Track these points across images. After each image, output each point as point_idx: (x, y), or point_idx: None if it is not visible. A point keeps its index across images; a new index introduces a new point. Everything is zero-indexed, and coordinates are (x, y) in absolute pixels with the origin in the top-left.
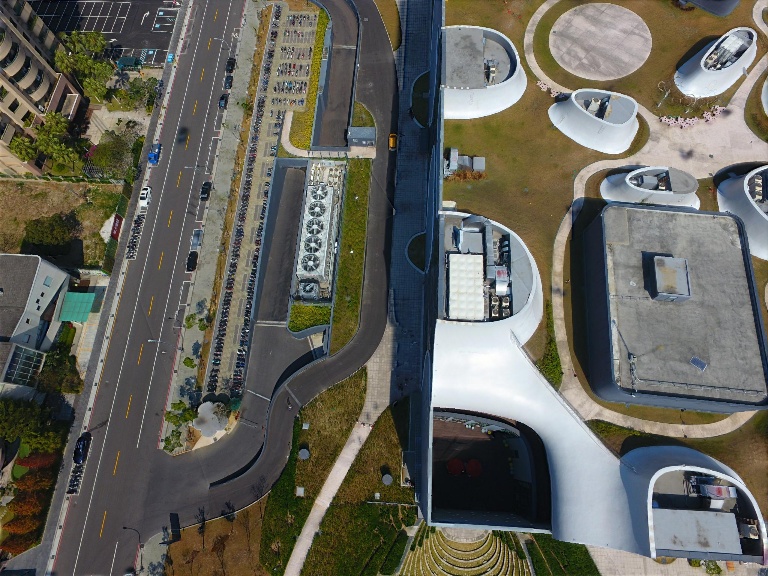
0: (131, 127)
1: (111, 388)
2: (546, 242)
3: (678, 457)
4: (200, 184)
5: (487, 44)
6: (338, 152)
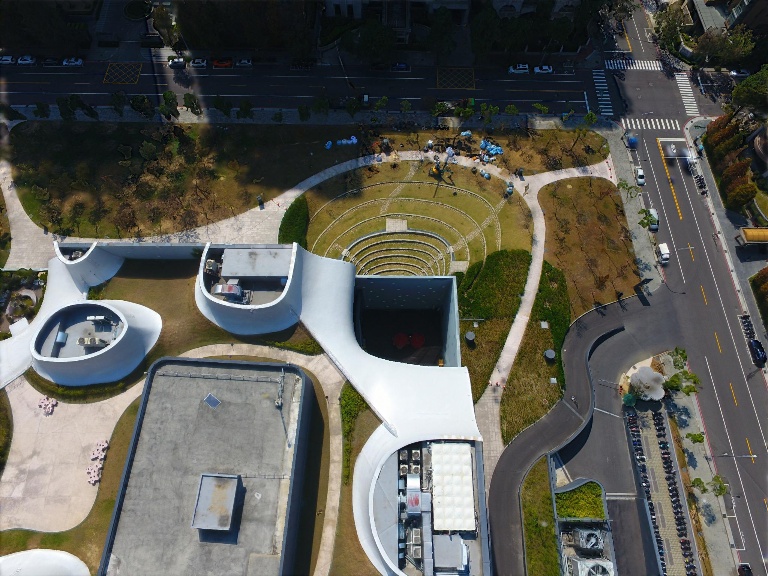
0: None
1: (762, 412)
2: (340, 572)
3: (249, 322)
4: None
5: None
6: None
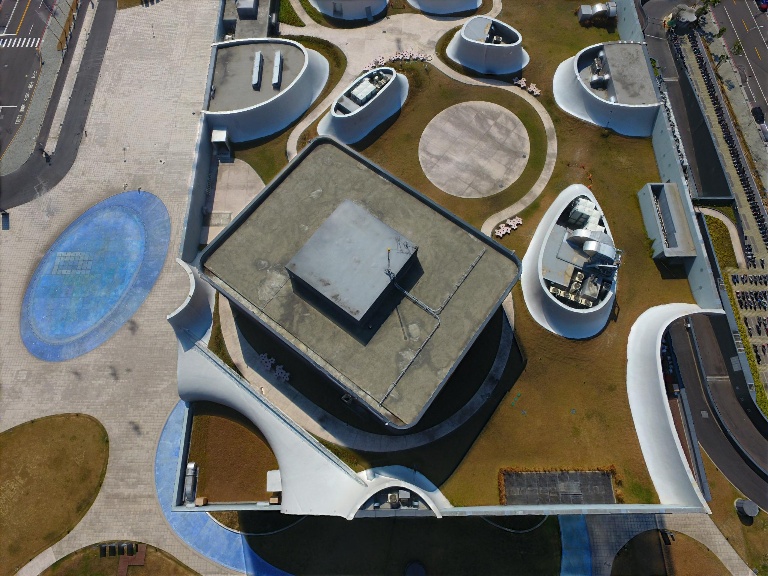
0: None
1: (766, 34)
2: None
3: None
4: None
5: None
6: None
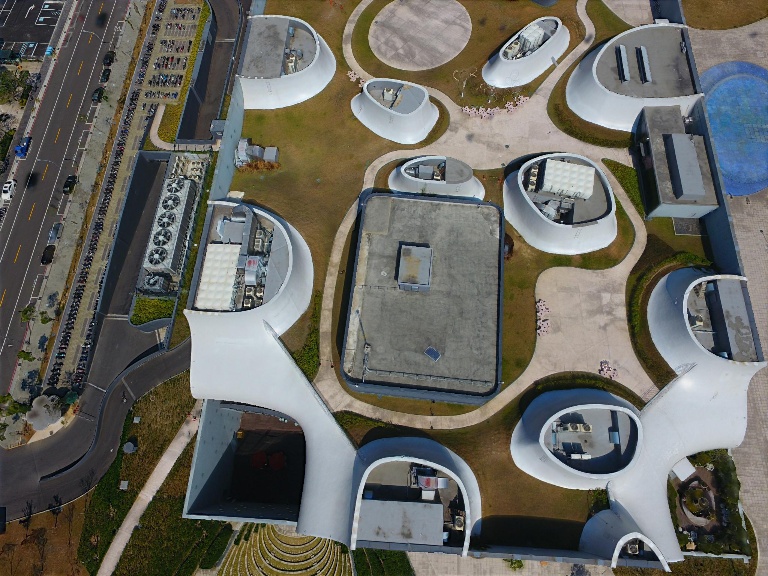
0: (3, 120)
1: None
2: (328, 233)
3: (412, 448)
4: (65, 177)
5: (297, 34)
6: (204, 145)
